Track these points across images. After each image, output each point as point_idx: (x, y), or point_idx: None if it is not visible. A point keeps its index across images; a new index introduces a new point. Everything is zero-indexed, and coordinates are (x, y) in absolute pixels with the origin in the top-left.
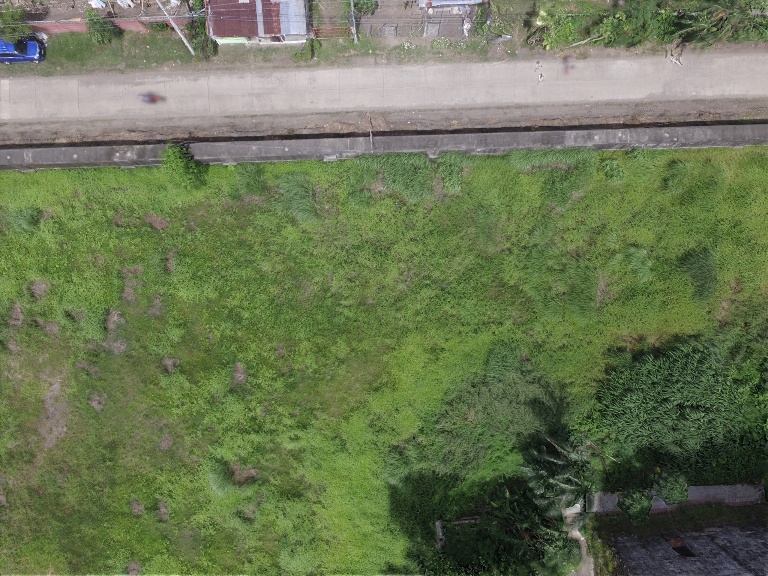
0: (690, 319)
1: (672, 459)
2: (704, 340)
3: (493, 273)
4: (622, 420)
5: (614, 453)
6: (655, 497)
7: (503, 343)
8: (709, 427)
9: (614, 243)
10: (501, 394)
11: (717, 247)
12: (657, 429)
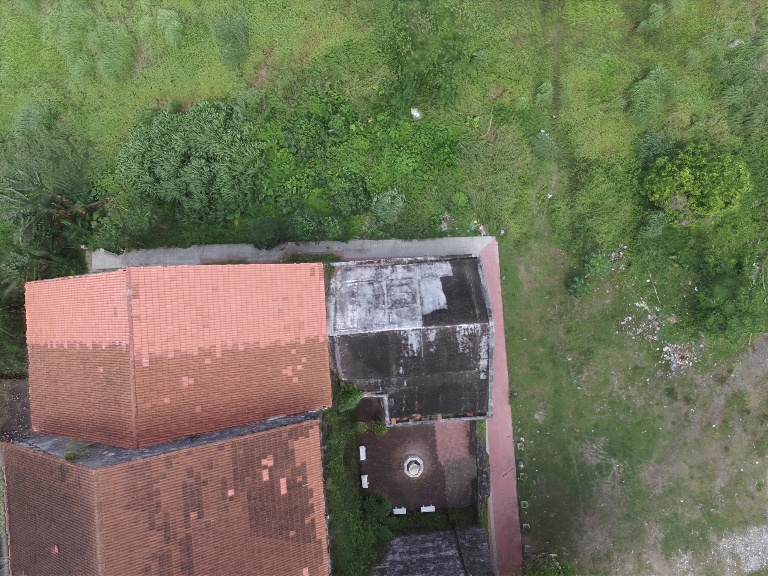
0: (220, 81)
1: (183, 210)
2: (229, 100)
3: (34, 37)
4: (124, 166)
5: (129, 205)
6: (180, 255)
7: (37, 103)
8: (216, 178)
9: (146, 5)
10: (24, 148)
11: (250, 12)
12: (158, 175)
